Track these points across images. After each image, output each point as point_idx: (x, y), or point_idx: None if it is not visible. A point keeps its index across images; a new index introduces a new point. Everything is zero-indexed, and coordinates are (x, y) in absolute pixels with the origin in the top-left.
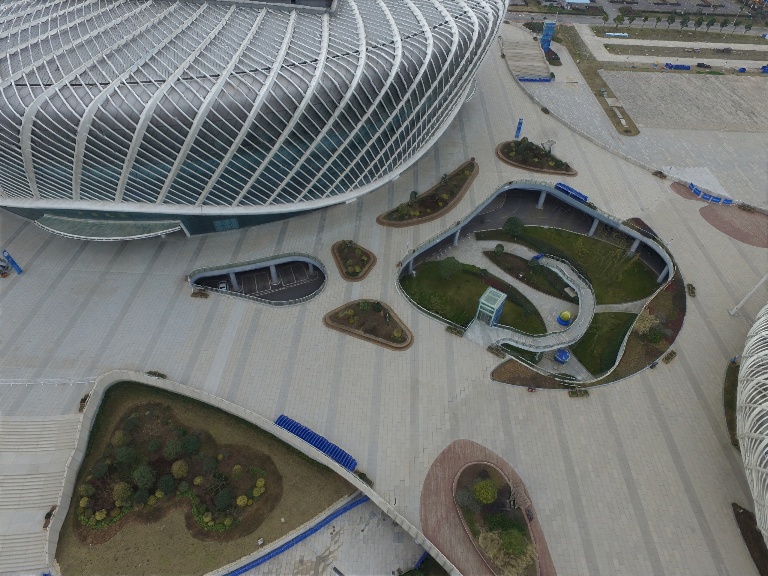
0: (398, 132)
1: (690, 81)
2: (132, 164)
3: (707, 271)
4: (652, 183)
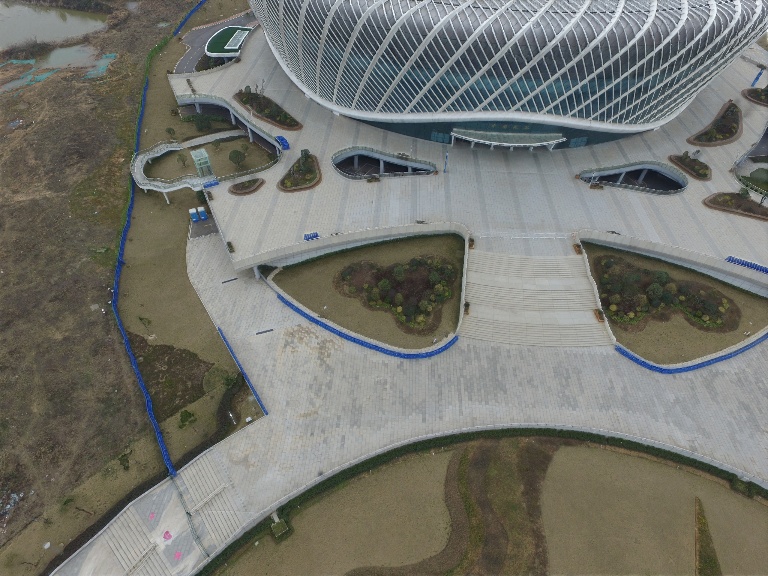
0: (725, 67)
1: None
2: (592, 78)
3: None
4: None
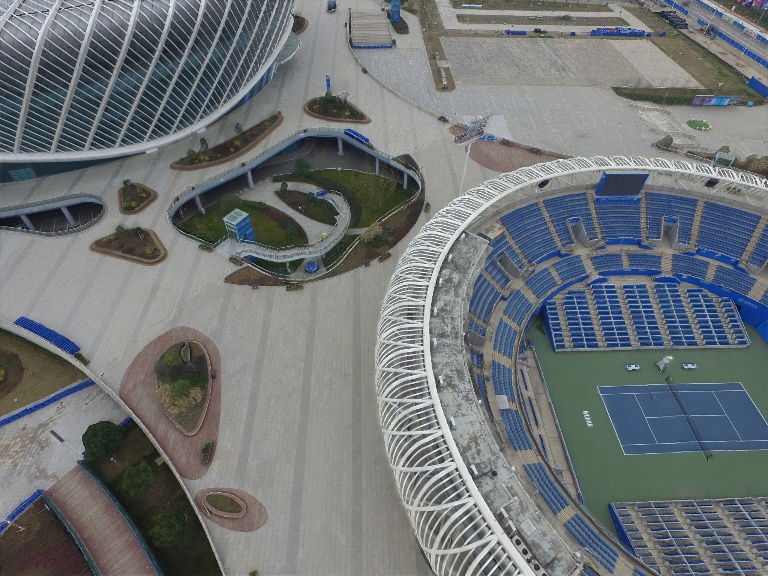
0: (172, 82)
1: (520, 44)
2: None
3: (449, 193)
4: (434, 126)
